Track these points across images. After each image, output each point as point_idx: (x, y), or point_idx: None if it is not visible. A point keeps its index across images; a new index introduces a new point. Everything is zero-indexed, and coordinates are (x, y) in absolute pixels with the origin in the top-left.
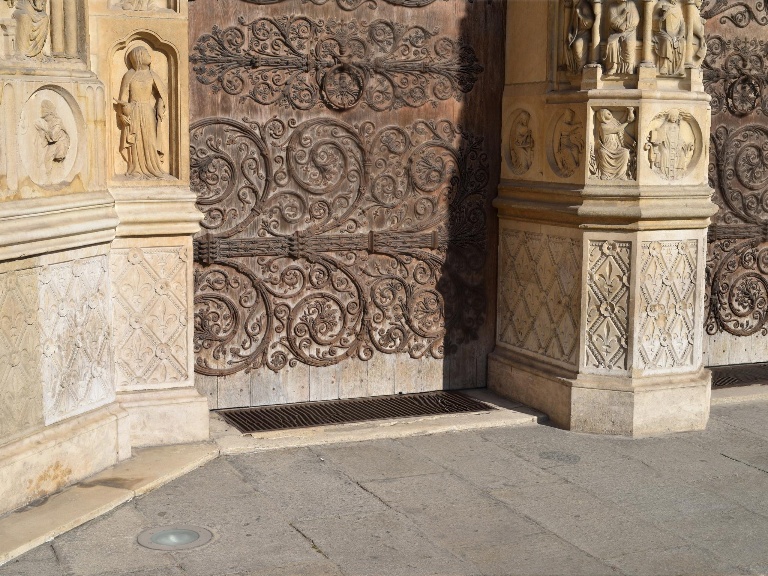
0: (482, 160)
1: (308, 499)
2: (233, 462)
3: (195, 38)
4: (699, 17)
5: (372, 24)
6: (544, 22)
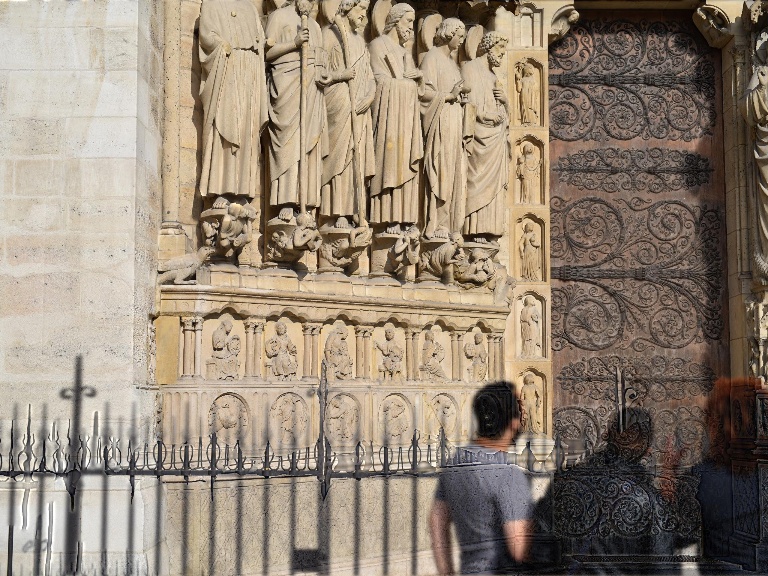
0: (720, 428)
1: None
2: (569, 570)
3: (561, 368)
4: None
5: (653, 358)
6: (742, 355)
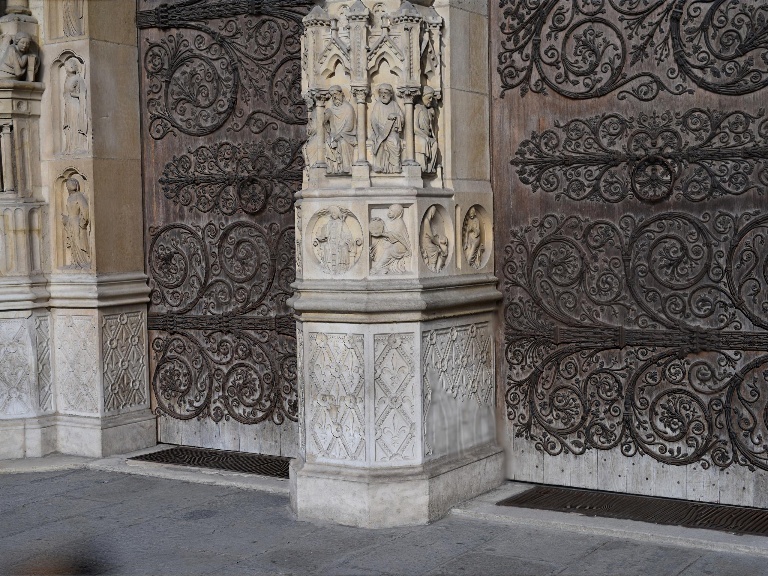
0: None
1: (7, 495)
2: (73, 472)
3: (164, 166)
4: (386, 113)
5: (274, 142)
6: None
